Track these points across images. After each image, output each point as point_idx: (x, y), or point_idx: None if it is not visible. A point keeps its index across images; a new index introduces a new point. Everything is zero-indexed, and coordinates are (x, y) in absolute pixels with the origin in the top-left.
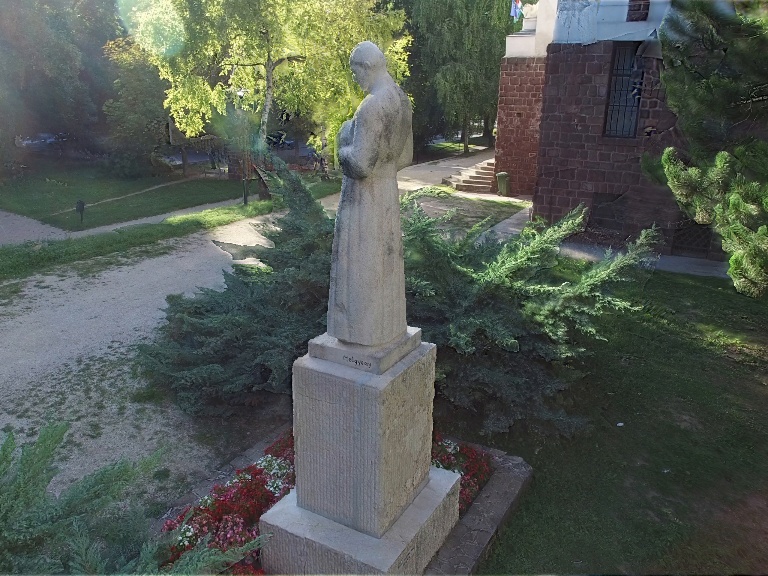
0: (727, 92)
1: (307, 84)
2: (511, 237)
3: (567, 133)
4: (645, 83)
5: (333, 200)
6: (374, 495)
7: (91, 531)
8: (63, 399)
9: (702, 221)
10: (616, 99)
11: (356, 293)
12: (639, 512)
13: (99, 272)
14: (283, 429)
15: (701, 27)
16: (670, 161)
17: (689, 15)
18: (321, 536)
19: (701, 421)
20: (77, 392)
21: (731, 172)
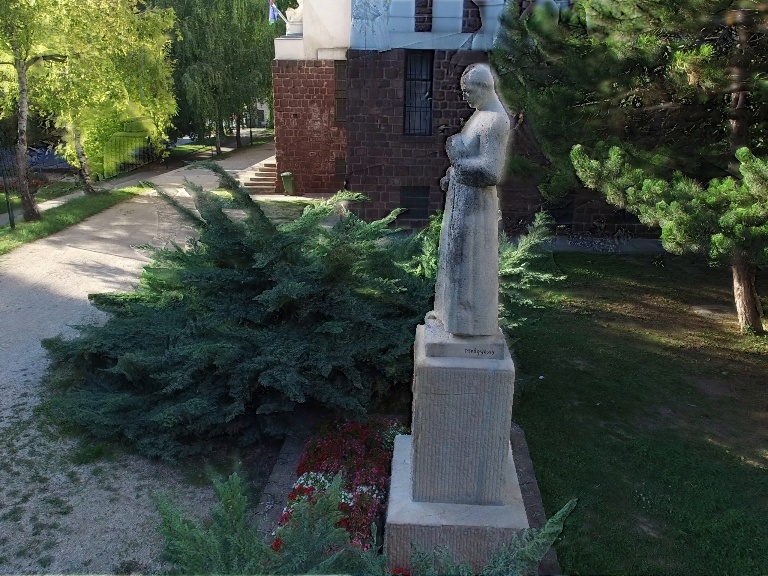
0: (565, 98)
1: (78, 87)
2: None
3: (372, 133)
4: (435, 87)
5: (114, 214)
6: (501, 467)
7: (332, 568)
8: None
9: (614, 202)
10: (412, 101)
11: (482, 290)
12: (605, 438)
13: None
14: (287, 448)
15: (526, 43)
16: (580, 156)
17: (514, 33)
18: (455, 519)
19: (590, 362)
20: None
21: (622, 162)
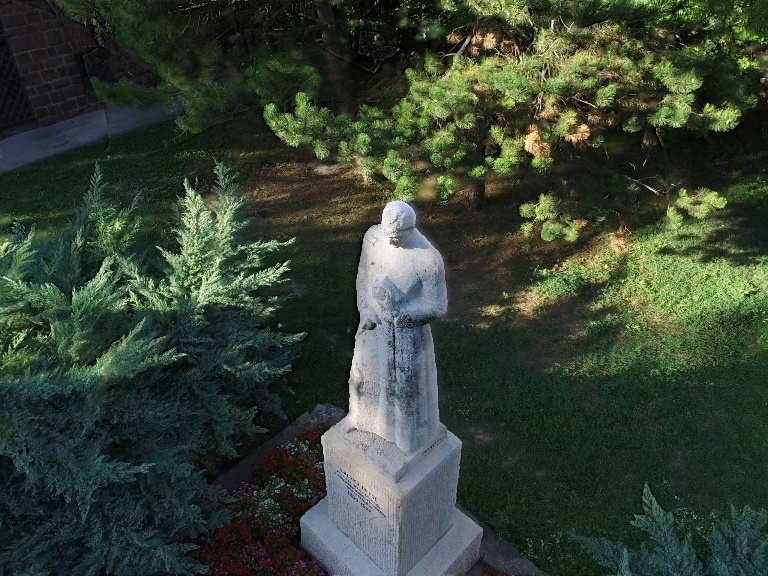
0: (163, 2)
1: None
2: None
3: None
4: None
5: None
6: None
7: None
8: None
9: None
10: None
11: None
12: None
13: None
14: None
15: None
16: (278, 117)
17: None
18: (439, 569)
19: (298, 282)
20: None
21: None
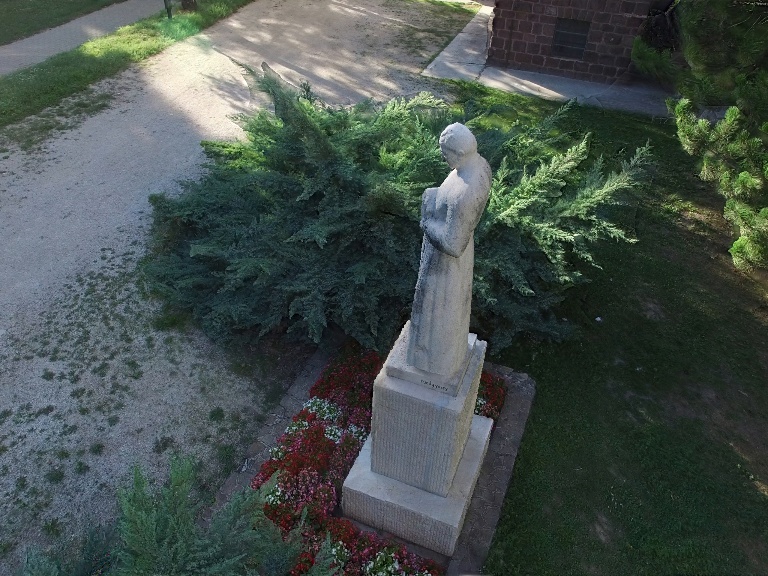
0: None
1: None
2: (490, 108)
3: None
4: None
5: (266, 5)
6: (444, 473)
7: None
8: (86, 333)
9: None
10: None
11: (438, 340)
12: (620, 414)
13: (43, 142)
14: (315, 360)
15: None
16: (684, 115)
17: None
18: (399, 499)
19: (663, 309)
20: (96, 322)
21: (738, 129)
